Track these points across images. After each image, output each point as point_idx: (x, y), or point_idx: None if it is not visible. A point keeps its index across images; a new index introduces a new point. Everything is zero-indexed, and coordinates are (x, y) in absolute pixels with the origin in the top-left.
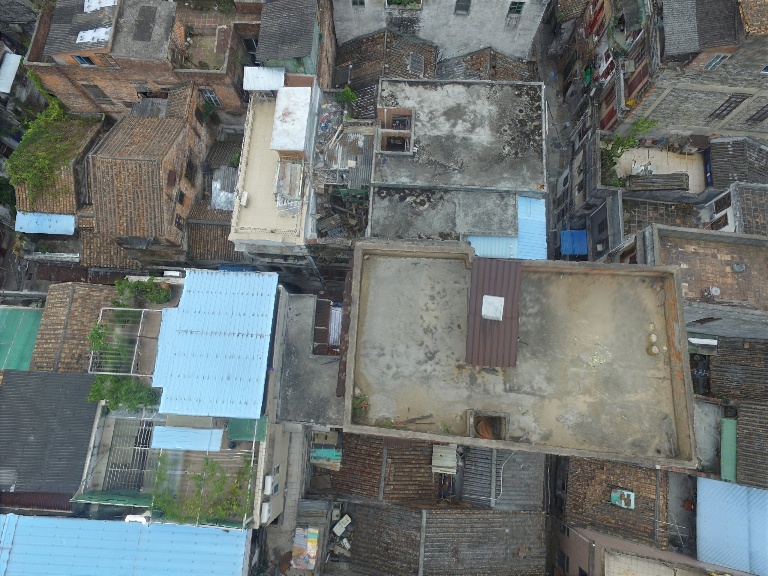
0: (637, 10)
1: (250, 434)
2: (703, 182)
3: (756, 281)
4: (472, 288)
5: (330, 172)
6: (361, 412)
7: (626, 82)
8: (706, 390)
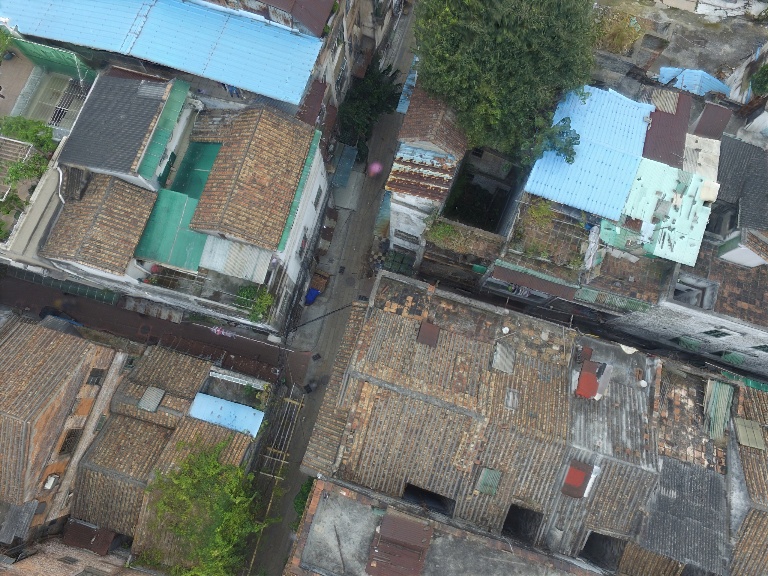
0: None
1: None
2: None
3: None
4: None
5: None
6: None
7: None
8: None
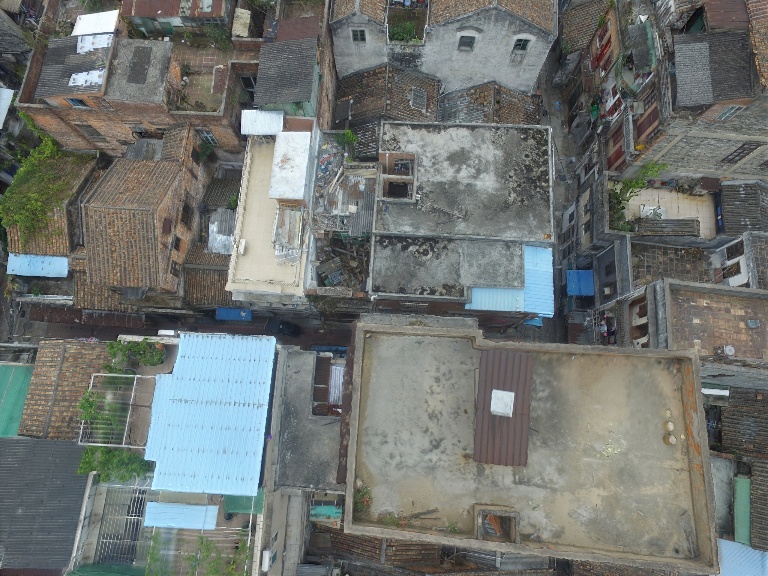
0: (647, 52)
1: (247, 506)
2: (714, 225)
3: None
4: (480, 382)
5: (330, 217)
6: (363, 506)
7: (635, 123)
8: (718, 443)
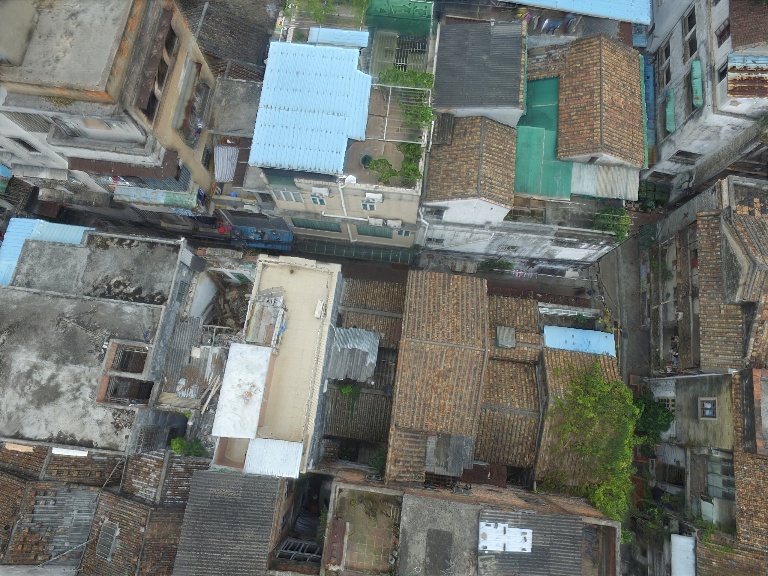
0: None
1: None
2: None
3: None
4: None
5: None
6: None
7: None
8: None
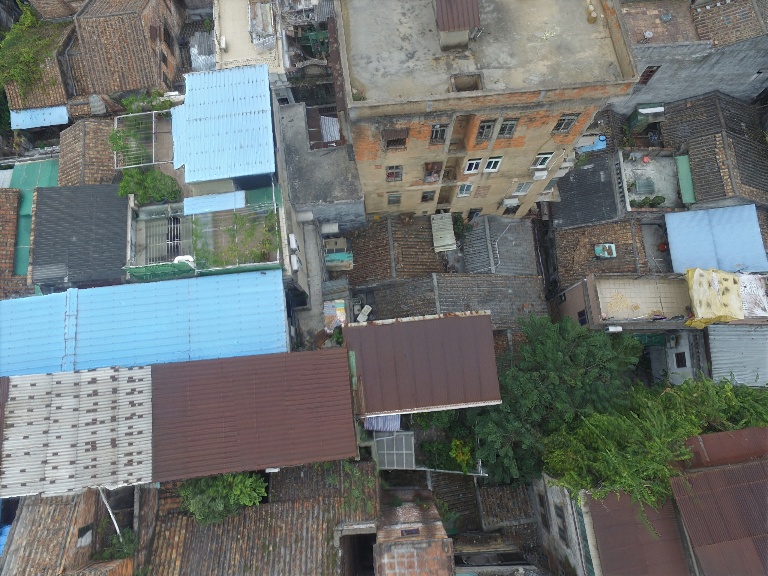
0: None
1: None
2: None
3: (682, 26)
4: None
5: (296, 14)
6: None
7: None
8: None
